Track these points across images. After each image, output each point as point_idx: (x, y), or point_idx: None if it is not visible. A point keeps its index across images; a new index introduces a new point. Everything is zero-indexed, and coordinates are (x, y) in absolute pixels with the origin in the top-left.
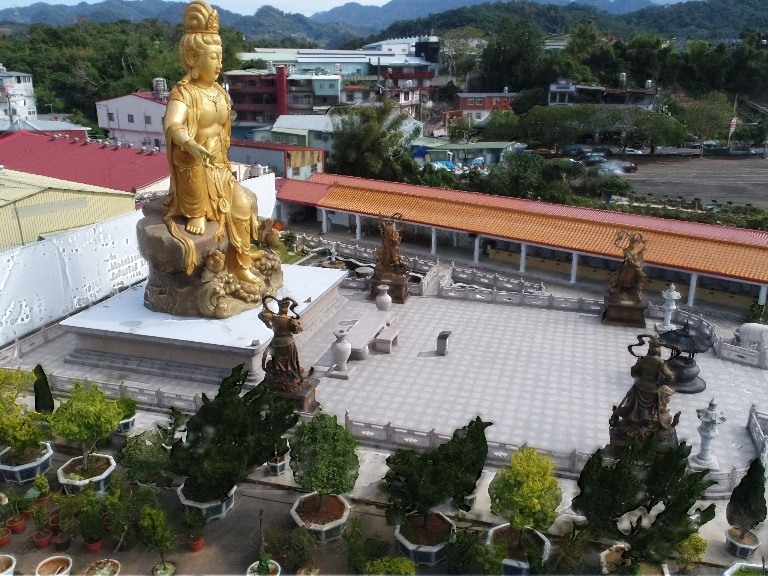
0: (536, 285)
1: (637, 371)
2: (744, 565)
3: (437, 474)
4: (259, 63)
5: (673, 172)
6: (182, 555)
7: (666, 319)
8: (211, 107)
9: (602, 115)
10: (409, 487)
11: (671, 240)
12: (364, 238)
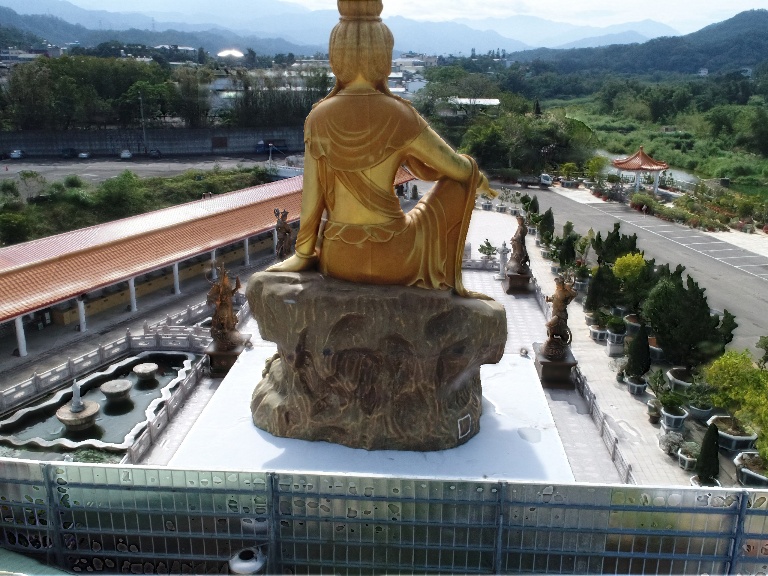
0: None
1: None
2: None
3: None
4: None
5: None
6: None
7: None
8: None
9: None
10: None
11: None
12: None
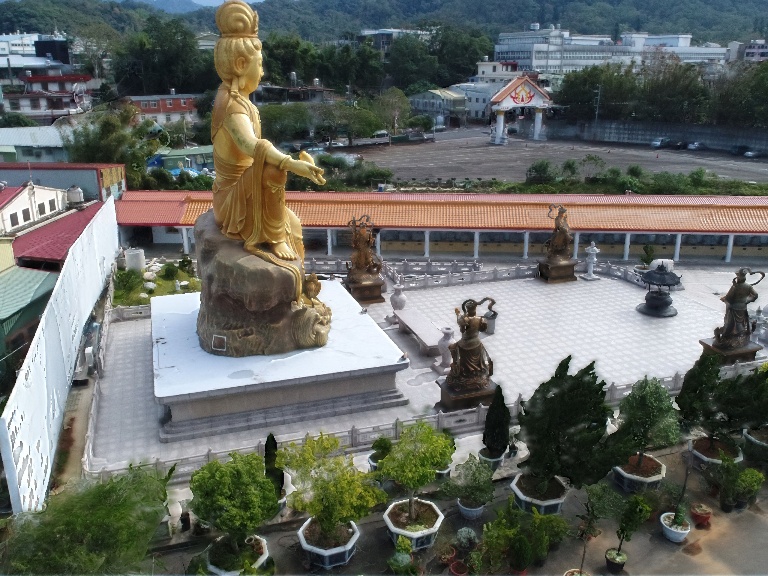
0: (470, 264)
1: (732, 297)
2: None
3: (762, 394)
4: None
5: (390, 159)
6: (587, 546)
7: (590, 270)
8: None
9: (315, 112)
10: (749, 411)
11: None
12: None
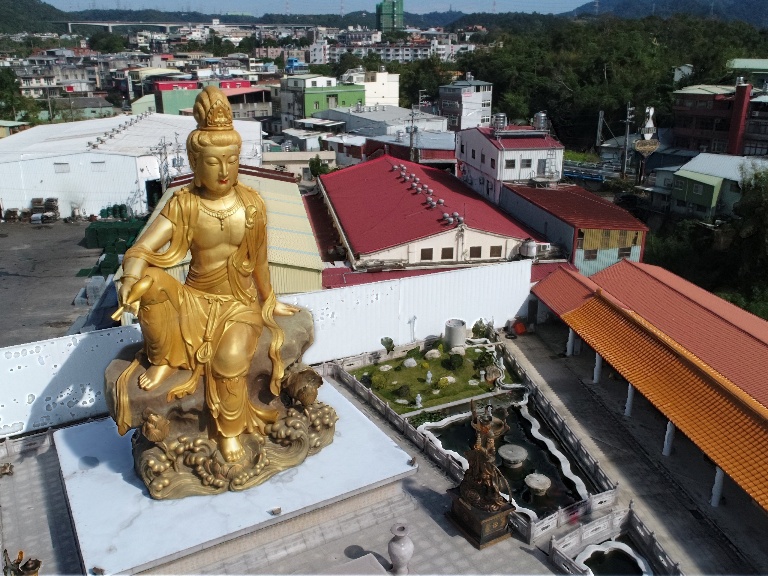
0: None
1: None
2: None
3: None
4: (742, 75)
5: None
6: None
7: None
8: (212, 224)
9: None
10: None
11: None
12: (604, 383)
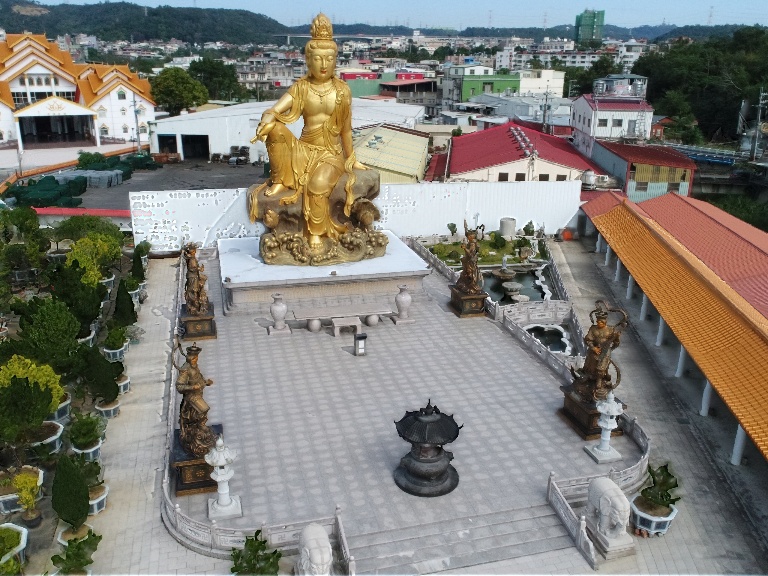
0: None
1: None
2: (22, 531)
3: None
4: None
5: None
6: None
7: (601, 439)
8: (316, 99)
9: None
10: None
11: (762, 355)
12: (612, 266)
